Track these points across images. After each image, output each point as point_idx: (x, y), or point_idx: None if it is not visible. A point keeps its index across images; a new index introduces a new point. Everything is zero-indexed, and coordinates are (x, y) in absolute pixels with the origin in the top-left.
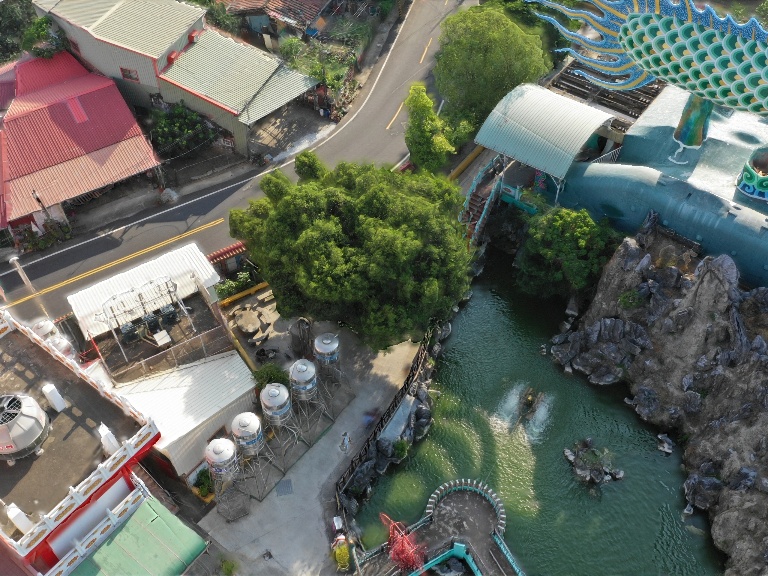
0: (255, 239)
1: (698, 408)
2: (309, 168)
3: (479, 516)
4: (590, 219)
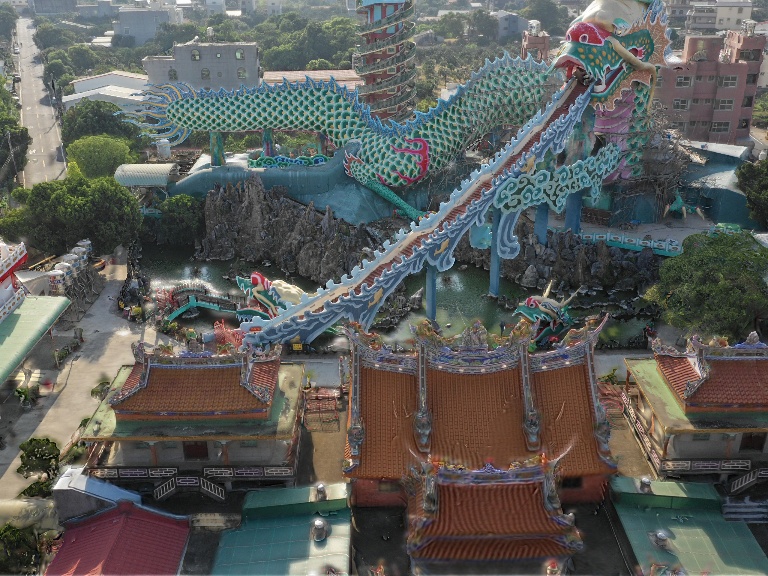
0: (17, 225)
1: (273, 244)
2: None
3: None
4: None
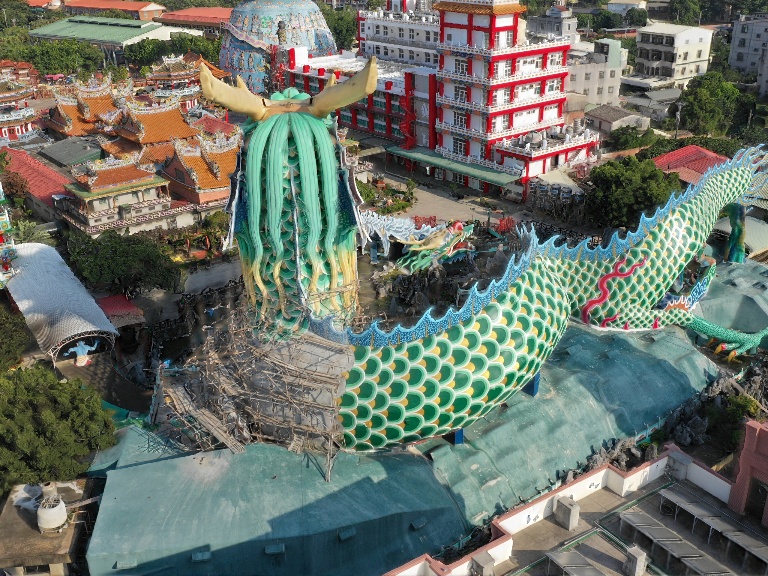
0: None
1: None
2: None
3: None
4: None
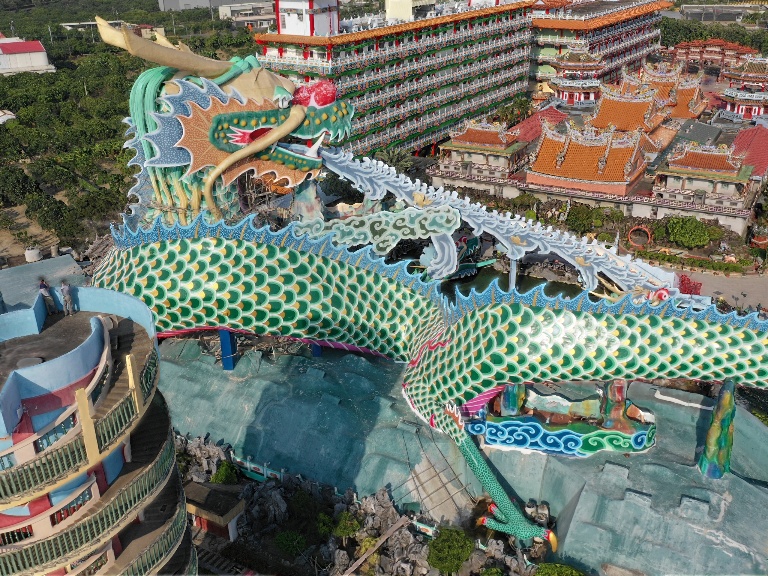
0: None
1: None
2: None
3: None
4: (760, 420)
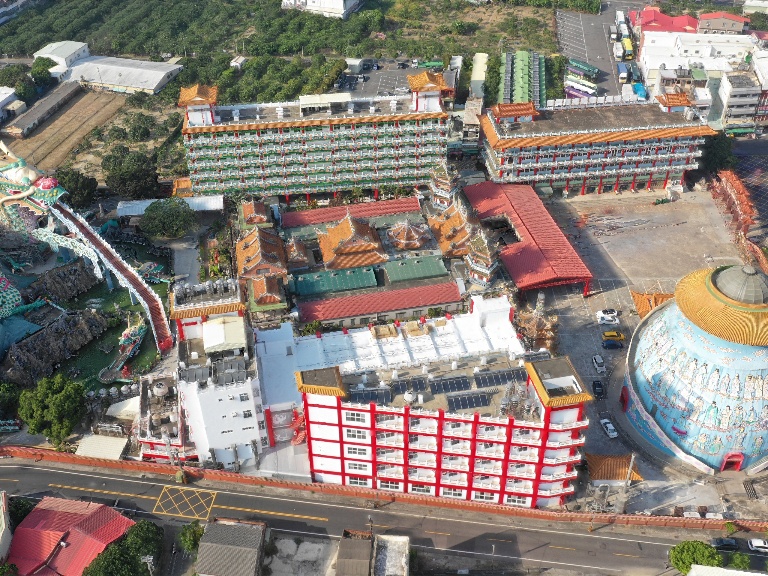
0: None
1: None
2: (37, 421)
3: None
4: None
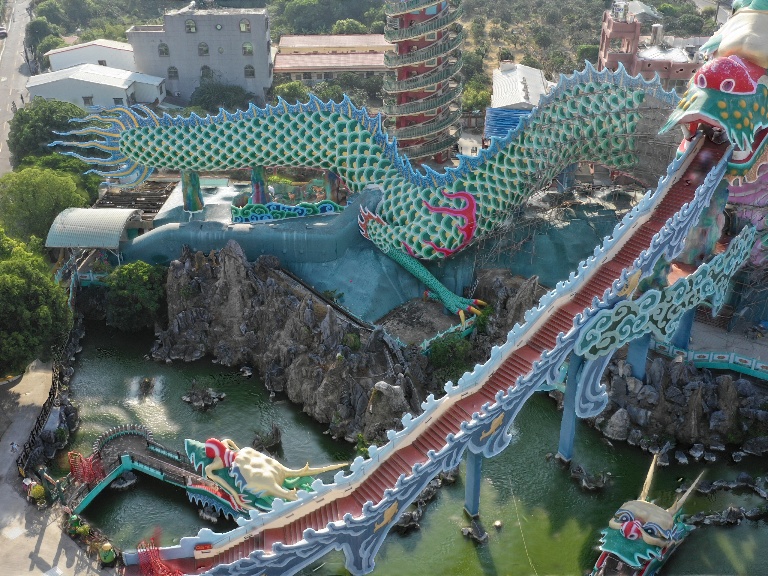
0: None
1: (257, 342)
2: None
3: (134, 444)
4: (146, 264)
